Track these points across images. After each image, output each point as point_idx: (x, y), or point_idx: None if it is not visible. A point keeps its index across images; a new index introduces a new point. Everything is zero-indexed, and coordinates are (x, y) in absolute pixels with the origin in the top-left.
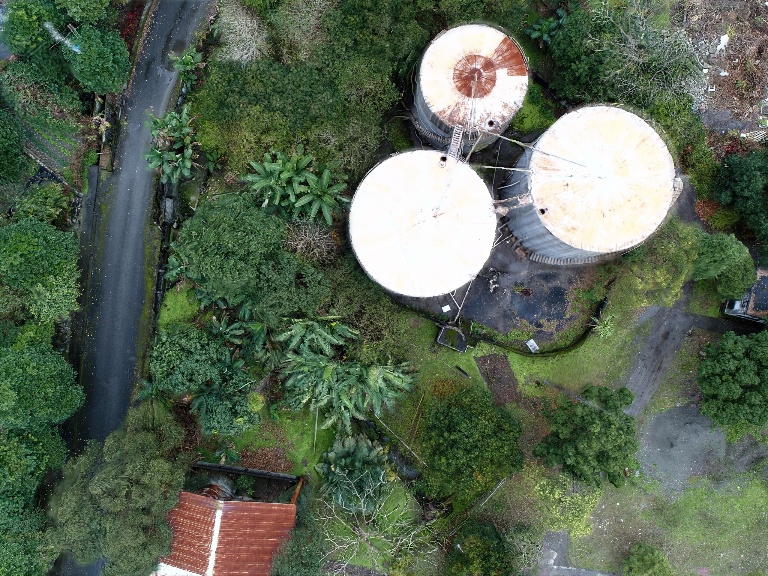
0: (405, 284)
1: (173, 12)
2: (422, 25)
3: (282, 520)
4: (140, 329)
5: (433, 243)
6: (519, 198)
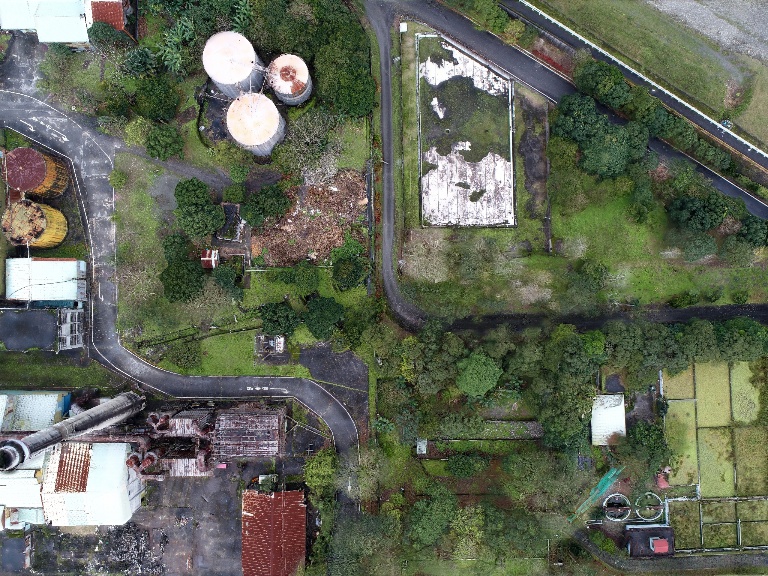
0: (206, 54)
1: None
2: None
3: (118, 25)
4: None
5: (221, 61)
6: None
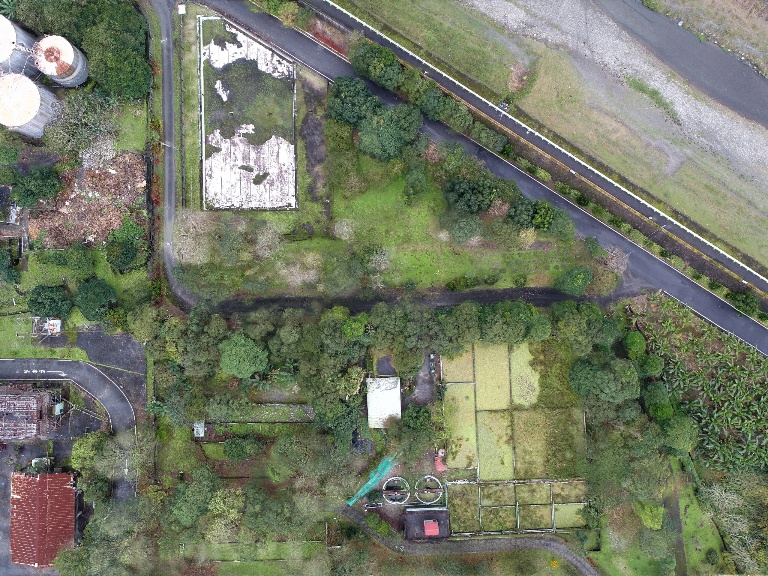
0: None
1: None
2: None
3: None
4: None
5: None
6: None
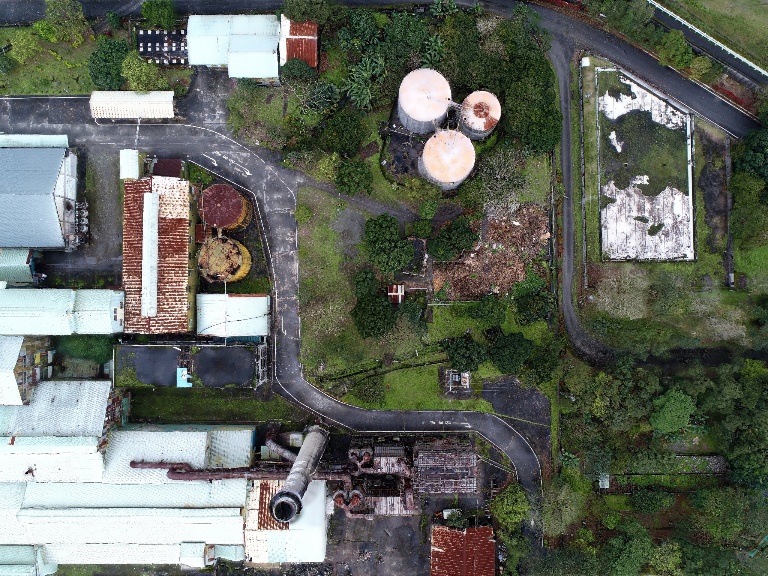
0: (403, 91)
1: (500, 2)
2: (502, 94)
3: (311, 62)
4: (370, 6)
5: (418, 98)
6: (438, 128)
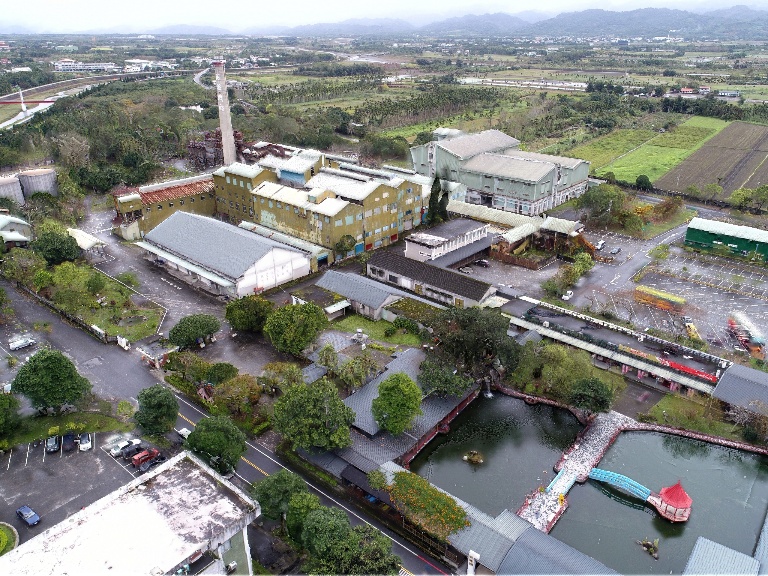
0: (1, 183)
1: None
2: None
3: None
4: None
5: (3, 179)
6: None
